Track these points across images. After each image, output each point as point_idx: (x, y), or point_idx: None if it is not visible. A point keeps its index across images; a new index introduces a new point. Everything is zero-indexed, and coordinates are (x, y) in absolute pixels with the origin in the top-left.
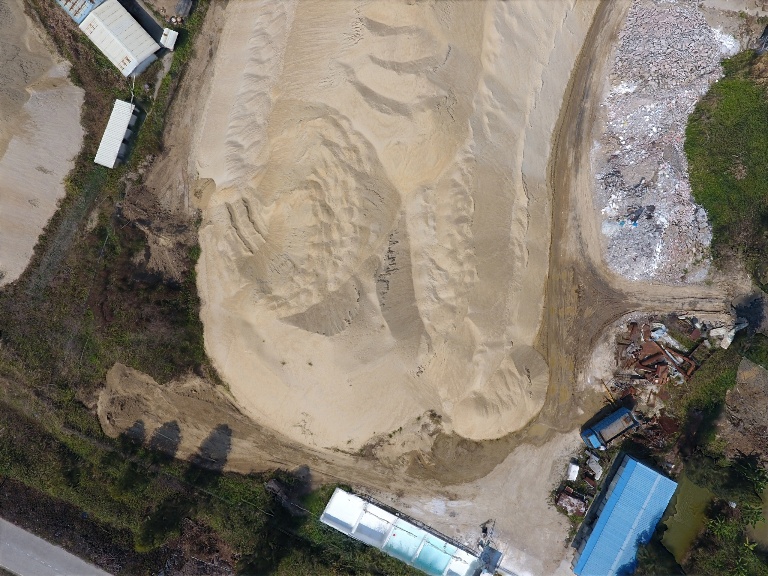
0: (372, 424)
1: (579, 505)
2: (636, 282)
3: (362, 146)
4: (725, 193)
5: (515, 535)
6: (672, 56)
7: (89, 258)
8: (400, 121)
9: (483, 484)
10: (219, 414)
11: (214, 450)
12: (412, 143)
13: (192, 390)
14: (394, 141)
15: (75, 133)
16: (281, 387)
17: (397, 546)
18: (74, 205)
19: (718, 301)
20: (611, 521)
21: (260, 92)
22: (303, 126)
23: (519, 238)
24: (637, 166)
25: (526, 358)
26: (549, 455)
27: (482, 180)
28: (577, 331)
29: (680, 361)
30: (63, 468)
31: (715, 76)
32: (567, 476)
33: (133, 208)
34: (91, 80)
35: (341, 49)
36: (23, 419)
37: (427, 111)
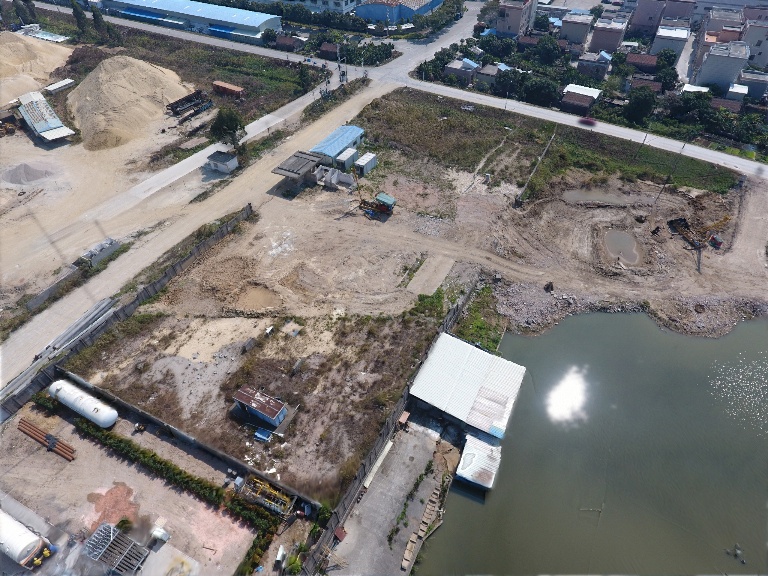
0: None
1: None
2: None
3: None
4: None
5: None
6: None
7: None
8: None
9: None
10: None
11: None
12: None
13: None
14: None
15: None
16: None
17: None
18: None
19: None
20: None
21: None
22: None
23: None
24: None
25: None
26: None
27: None
28: None
29: None
30: (143, 42)
31: None
32: None
33: None
34: None
35: None
36: None
37: None
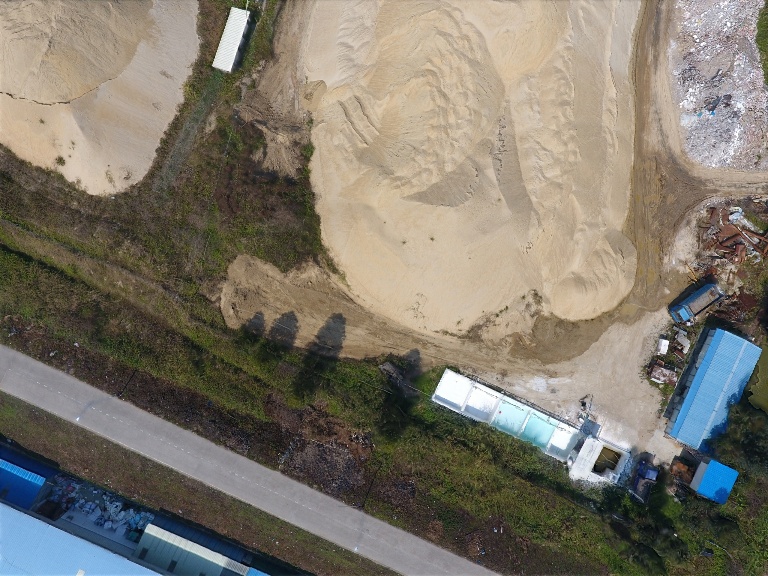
0: (482, 302)
1: (671, 375)
2: (713, 169)
3: (473, 35)
4: None
5: (612, 408)
6: None
7: (212, 155)
8: (510, 9)
9: (580, 362)
10: (334, 304)
11: (330, 338)
12: (520, 30)
13: (308, 281)
14: (503, 29)
15: (192, 41)
16: (400, 267)
17: (503, 423)
18: (192, 110)
19: None
20: (703, 386)
21: None
22: (415, 21)
23: (610, 127)
24: (713, 60)
25: (618, 241)
26: (640, 333)
27: (579, 69)
28: (661, 217)
29: (756, 241)
30: (191, 357)
31: None
32: (658, 350)
33: (250, 110)
34: None
35: None
36: (147, 316)
37: None
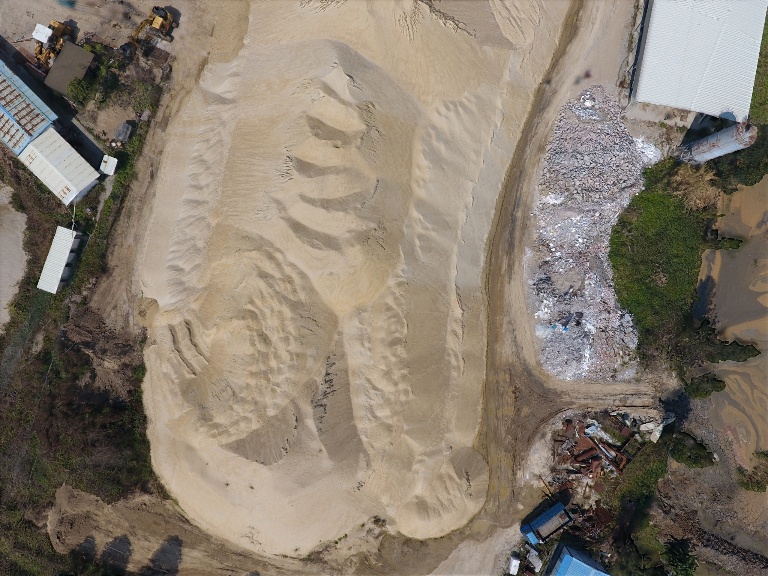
0: (317, 534)
1: None
2: (569, 381)
3: (296, 277)
4: (648, 300)
5: None
6: (595, 171)
7: (34, 384)
8: (331, 255)
9: None
10: (169, 526)
11: (165, 561)
12: (344, 274)
13: (142, 504)
14: (327, 272)
15: (18, 259)
16: (226, 505)
17: None
18: (19, 328)
19: (647, 397)
20: None
21: (199, 217)
22: (240, 256)
23: (455, 348)
24: (566, 274)
25: (466, 460)
26: (491, 550)
27: (415, 300)
28: (515, 430)
29: (613, 455)
30: None
31: (635, 190)
32: (509, 570)
33: (77, 331)
34: (33, 205)
35: (273, 185)
36: None
37: (356, 246)
